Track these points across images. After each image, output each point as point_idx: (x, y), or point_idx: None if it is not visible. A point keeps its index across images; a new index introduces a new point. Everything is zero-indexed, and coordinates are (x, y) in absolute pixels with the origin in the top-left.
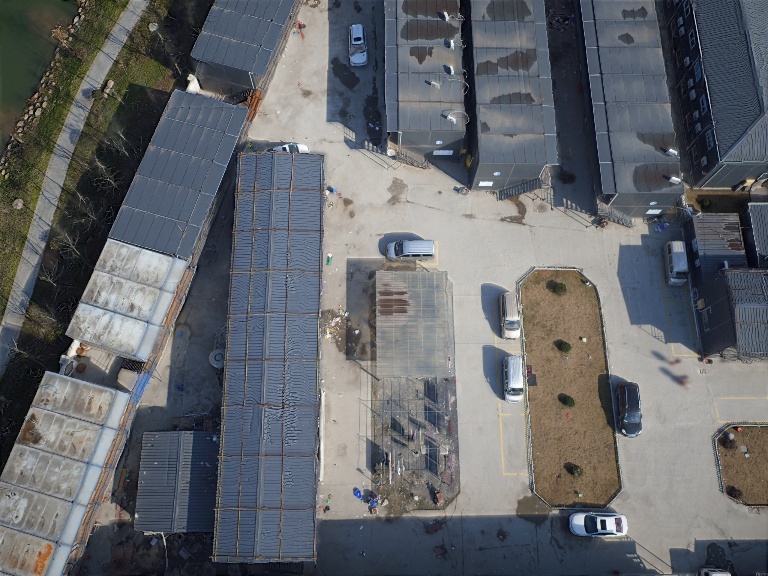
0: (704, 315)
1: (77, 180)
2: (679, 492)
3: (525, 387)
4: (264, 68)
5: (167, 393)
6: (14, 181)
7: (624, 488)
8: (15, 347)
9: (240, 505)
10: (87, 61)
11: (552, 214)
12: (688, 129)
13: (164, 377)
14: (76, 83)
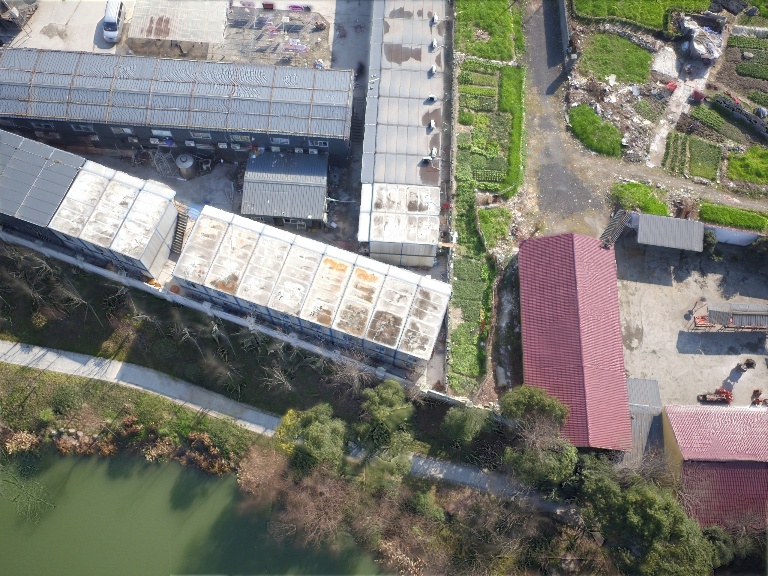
0: None
1: None
2: None
3: None
4: None
5: None
6: None
7: None
8: (143, 317)
9: (307, 117)
10: None
11: None
12: None
13: None
14: None
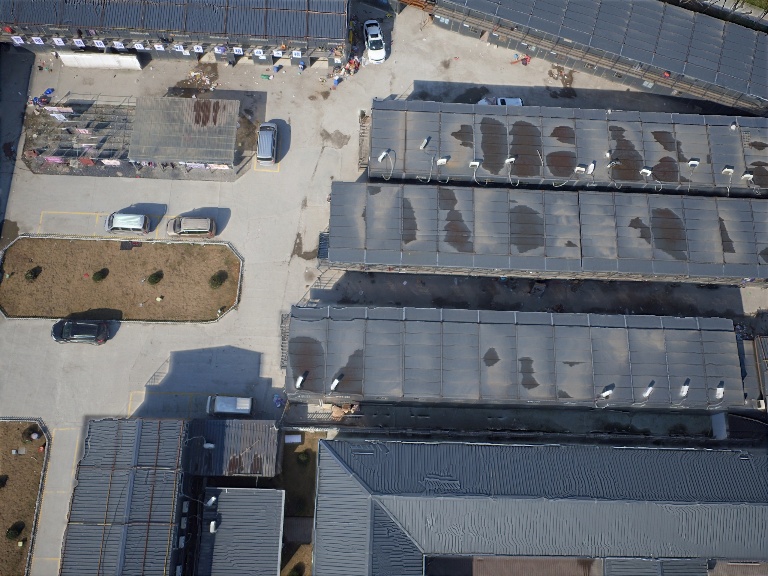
0: None
1: None
2: None
3: (121, 239)
4: None
5: None
6: None
7: (8, 320)
8: None
9: None
10: None
11: (302, 286)
12: None
13: None
14: None
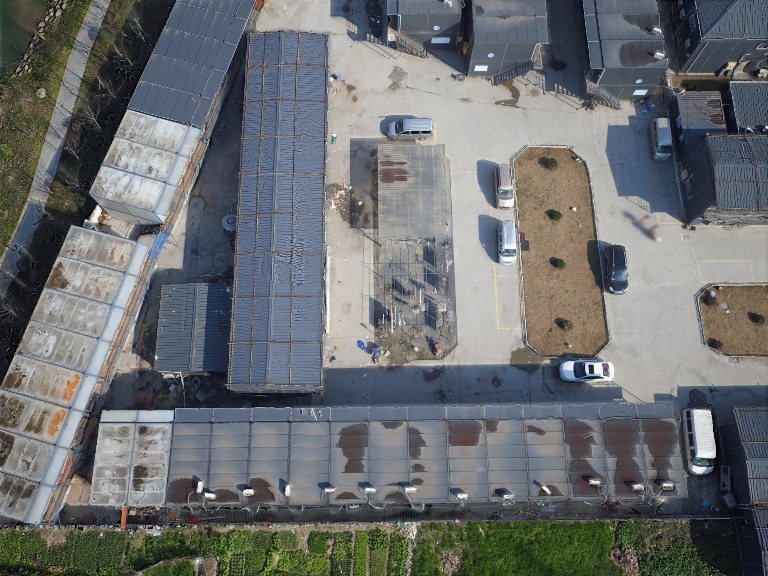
0: (687, 185)
1: (96, 72)
2: (663, 344)
3: (518, 252)
4: None
5: (183, 257)
6: (37, 74)
7: (611, 341)
8: (42, 208)
9: (252, 339)
10: None
11: (544, 98)
12: (673, 19)
13: (180, 243)
14: None
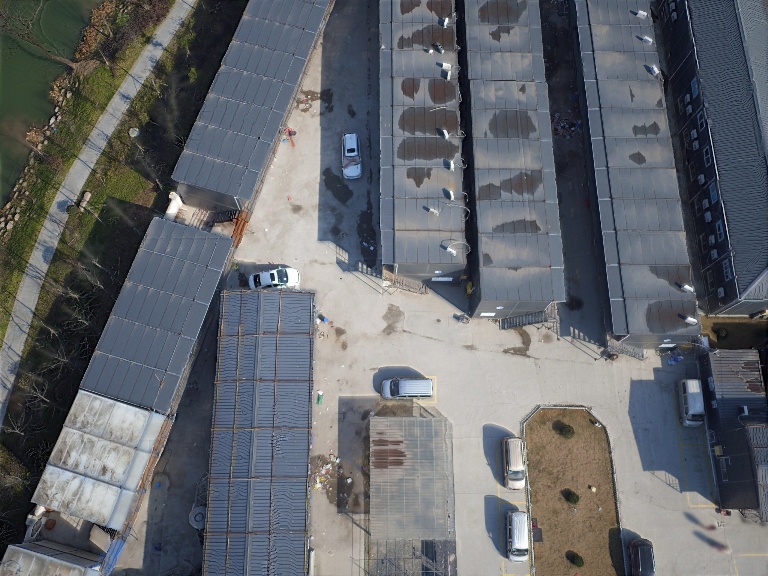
0: (722, 463)
1: (50, 305)
2: None
3: (530, 543)
4: (250, 192)
5: (143, 553)
6: None
7: None
8: None
9: None
10: (63, 170)
11: (558, 345)
12: (703, 251)
13: (140, 534)
14: (51, 194)
